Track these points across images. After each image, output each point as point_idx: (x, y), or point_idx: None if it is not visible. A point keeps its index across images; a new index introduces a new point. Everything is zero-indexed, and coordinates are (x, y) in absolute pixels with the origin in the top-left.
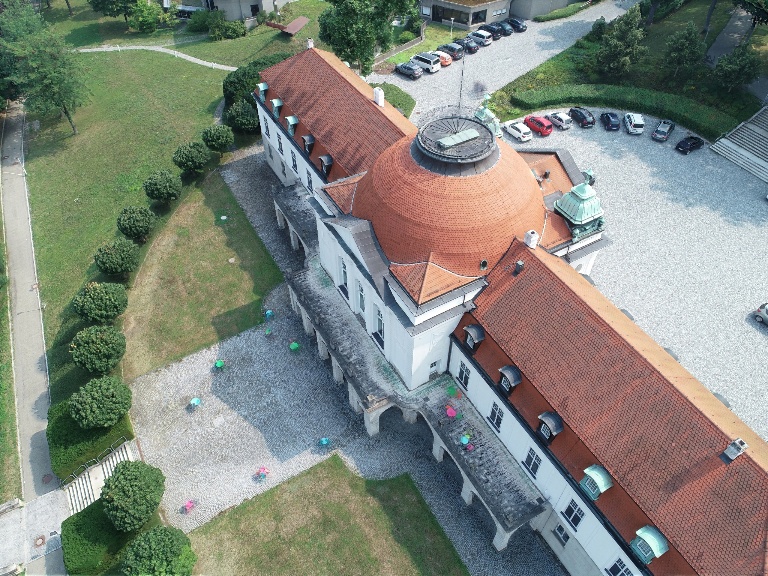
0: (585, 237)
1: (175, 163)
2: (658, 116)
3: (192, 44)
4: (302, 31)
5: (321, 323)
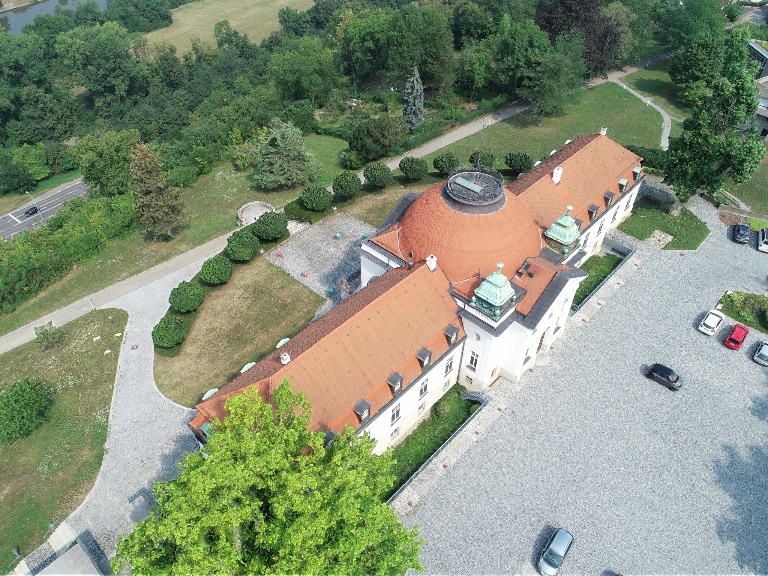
0: (480, 310)
1: (505, 156)
2: None
3: None
4: None
5: None
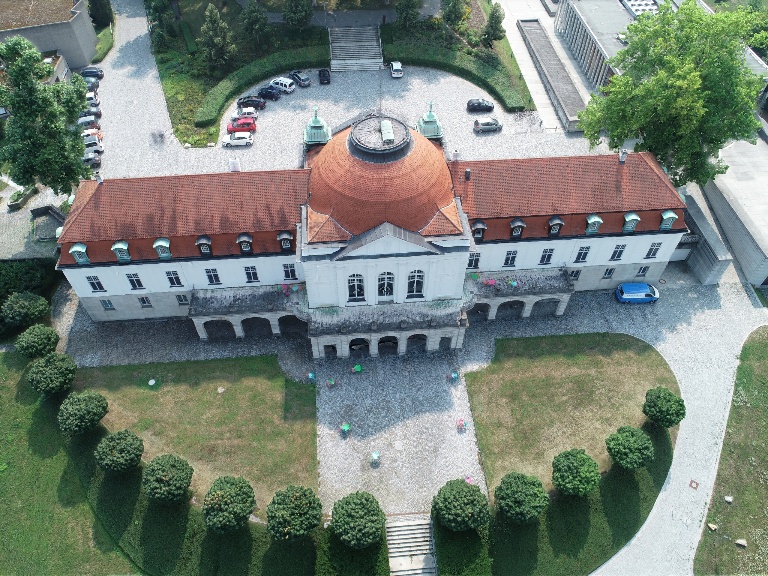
0: None
1: (54, 391)
2: (281, 73)
3: None
4: None
5: (381, 324)
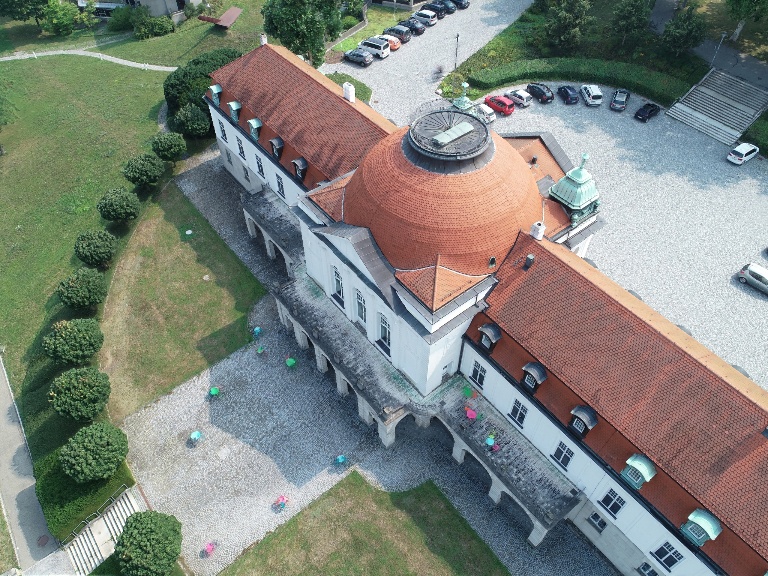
0: (583, 221)
1: (128, 179)
2: (612, 85)
3: (117, 45)
4: (237, 23)
5: (321, 337)
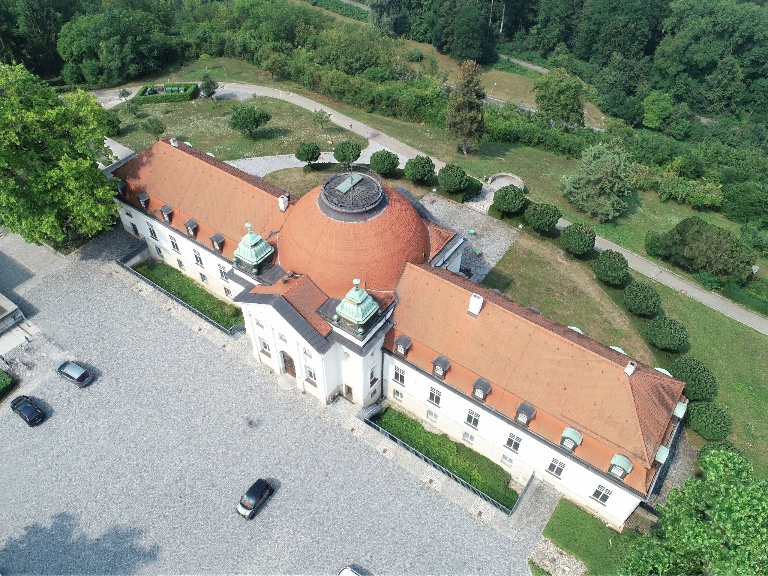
0: None
1: None
2: None
3: None
4: None
5: None
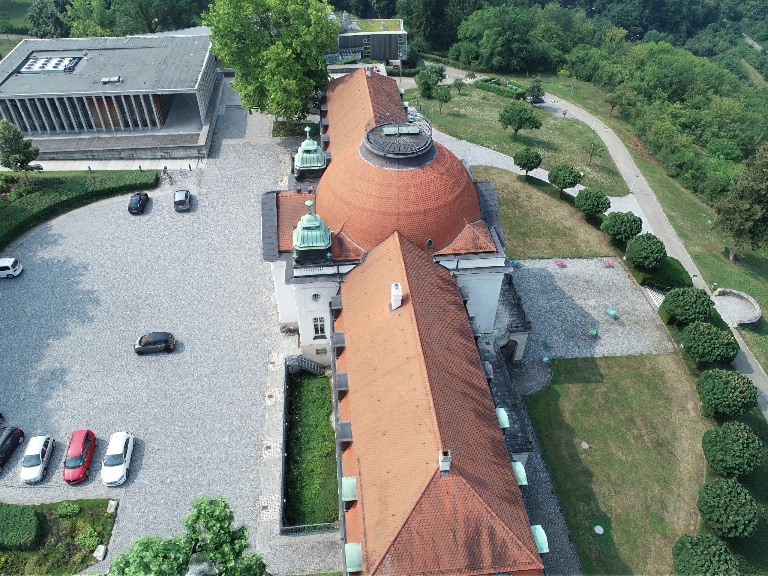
0: None
1: None
2: None
3: None
4: None
5: None
